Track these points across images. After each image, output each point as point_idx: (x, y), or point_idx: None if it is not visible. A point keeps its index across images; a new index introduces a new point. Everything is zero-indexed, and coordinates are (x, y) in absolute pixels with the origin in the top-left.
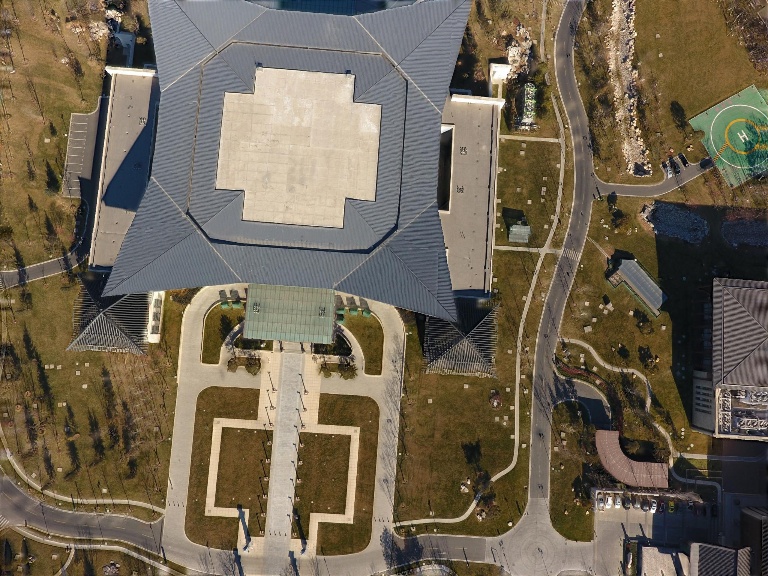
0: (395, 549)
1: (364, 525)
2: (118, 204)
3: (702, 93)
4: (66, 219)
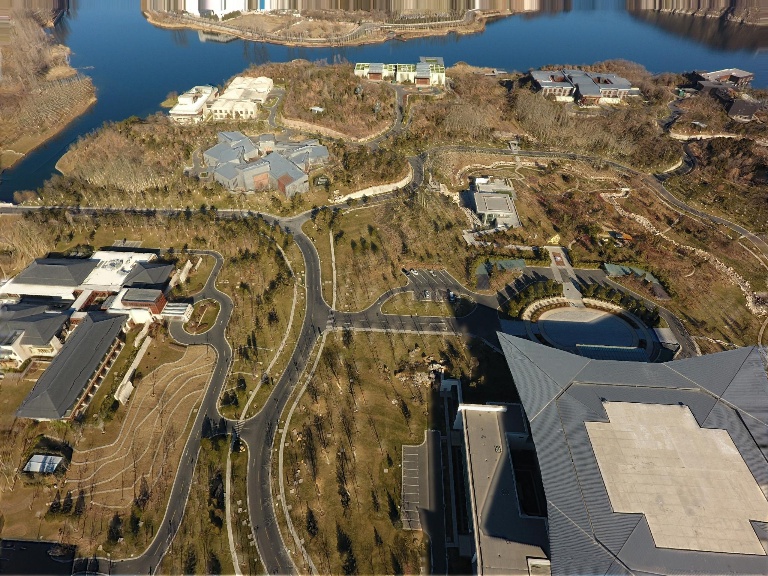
0: None
1: None
2: (496, 533)
3: None
4: (410, 555)
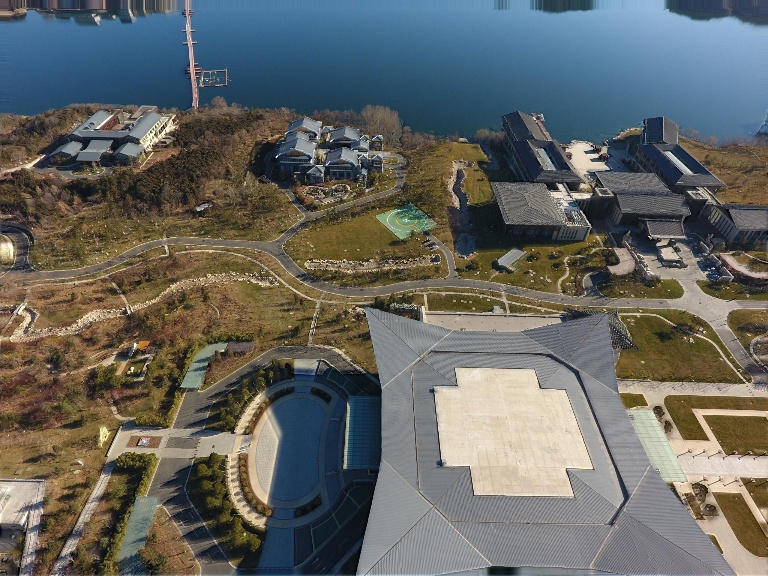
0: (763, 382)
1: (763, 403)
2: None
3: (382, 234)
4: None
